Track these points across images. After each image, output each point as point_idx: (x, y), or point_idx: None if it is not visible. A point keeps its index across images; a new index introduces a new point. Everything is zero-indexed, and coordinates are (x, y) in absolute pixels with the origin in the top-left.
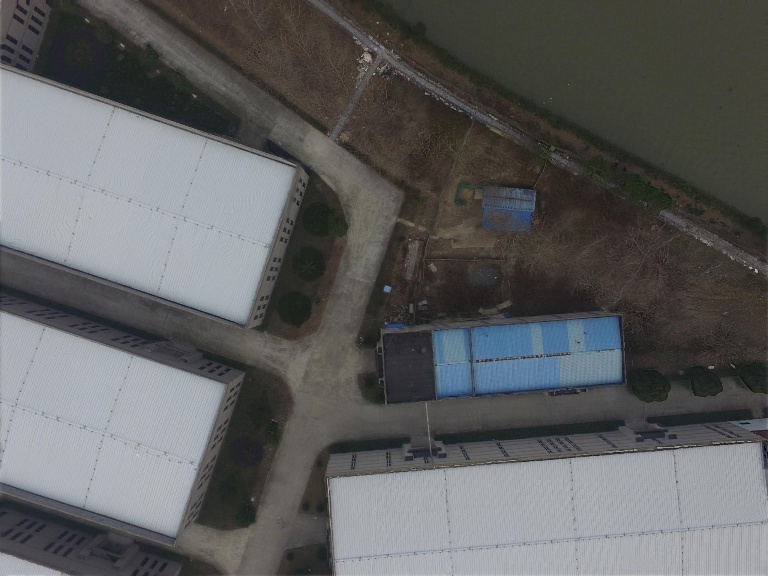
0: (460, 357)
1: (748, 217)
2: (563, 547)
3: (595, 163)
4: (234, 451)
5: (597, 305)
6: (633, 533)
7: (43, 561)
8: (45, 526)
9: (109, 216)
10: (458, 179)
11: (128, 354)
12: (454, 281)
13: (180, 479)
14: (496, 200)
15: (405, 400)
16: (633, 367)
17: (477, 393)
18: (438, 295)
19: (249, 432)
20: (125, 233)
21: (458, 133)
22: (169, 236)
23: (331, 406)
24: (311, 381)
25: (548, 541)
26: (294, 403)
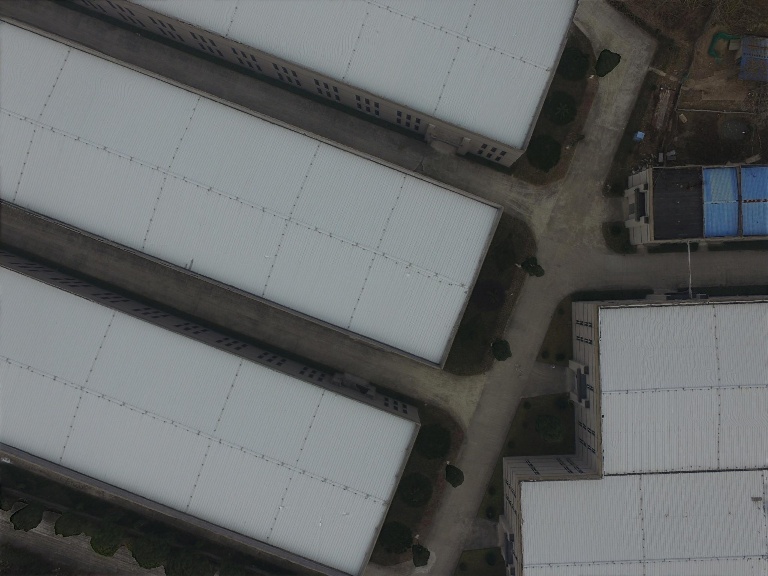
0: (727, 196)
1: None
2: None
3: None
4: (477, 294)
5: None
6: None
7: (307, 379)
8: (286, 360)
9: (397, 30)
10: (714, 29)
11: (401, 174)
12: (704, 133)
13: (449, 302)
14: (755, 49)
15: (671, 237)
16: None
17: None
18: (687, 146)
19: (493, 275)
20: (412, 47)
21: None
22: (450, 56)
23: (574, 254)
24: (555, 227)
25: None
26: (537, 249)
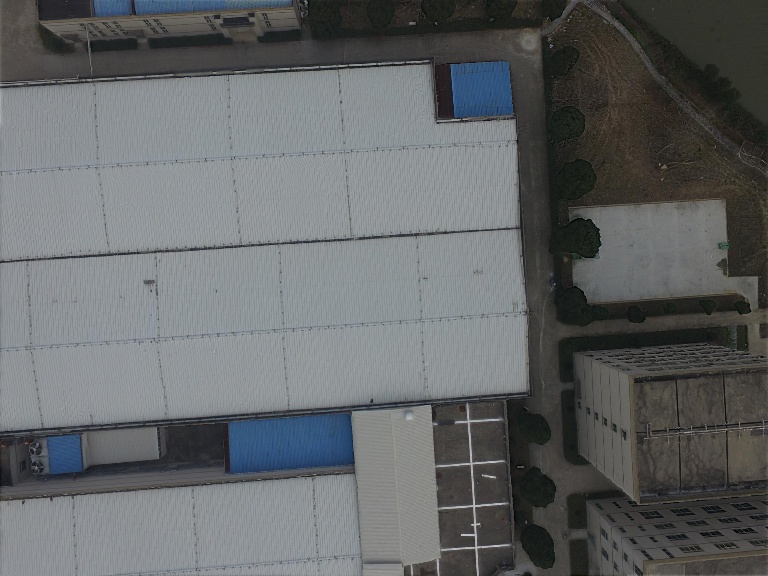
0: None
1: None
2: (219, 166)
3: None
4: None
5: None
6: (293, 153)
7: None
8: None
9: None
10: None
11: None
12: None
13: None
14: None
15: (60, 18)
16: None
17: None
18: None
19: None
20: None
21: None
22: None
23: (11, 55)
24: None
25: (202, 159)
26: None
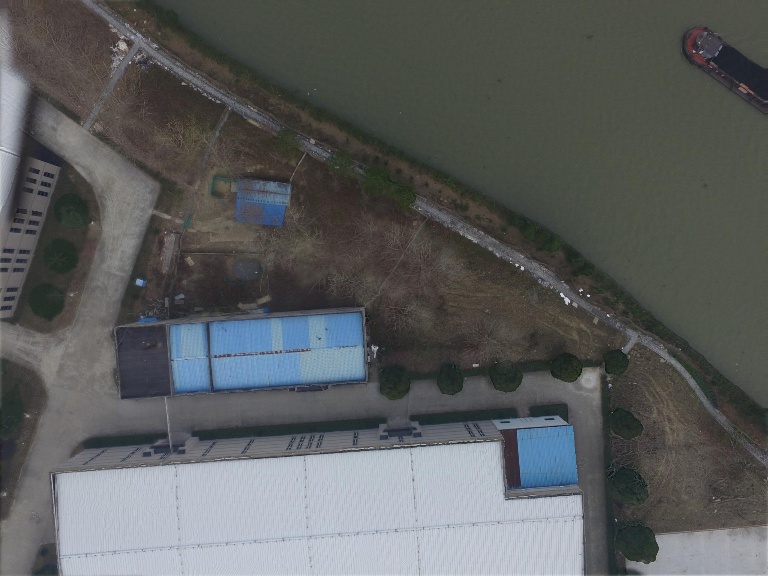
0: (198, 352)
1: (514, 213)
2: (295, 545)
3: (357, 157)
4: None
5: (357, 301)
6: (367, 532)
7: None
8: None
9: None
10: (213, 171)
11: None
12: (212, 275)
13: None
14: (249, 193)
15: (141, 395)
16: (391, 364)
17: (216, 389)
18: None
19: None
20: None
21: (211, 124)
22: None
23: (86, 401)
24: (65, 375)
25: (280, 539)
26: (48, 397)
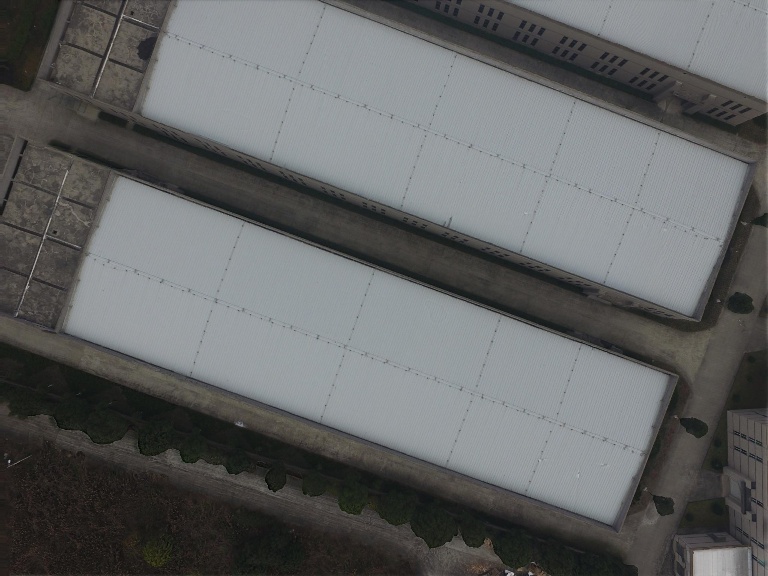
0: None
1: None
2: None
3: None
4: None
5: None
6: None
7: (566, 334)
8: None
9: None
10: None
11: (655, 130)
12: None
13: (704, 256)
14: None
15: None
16: None
17: None
18: None
19: None
20: (673, 3)
21: None
22: (704, 13)
23: None
24: None
25: None
26: (760, 207)
